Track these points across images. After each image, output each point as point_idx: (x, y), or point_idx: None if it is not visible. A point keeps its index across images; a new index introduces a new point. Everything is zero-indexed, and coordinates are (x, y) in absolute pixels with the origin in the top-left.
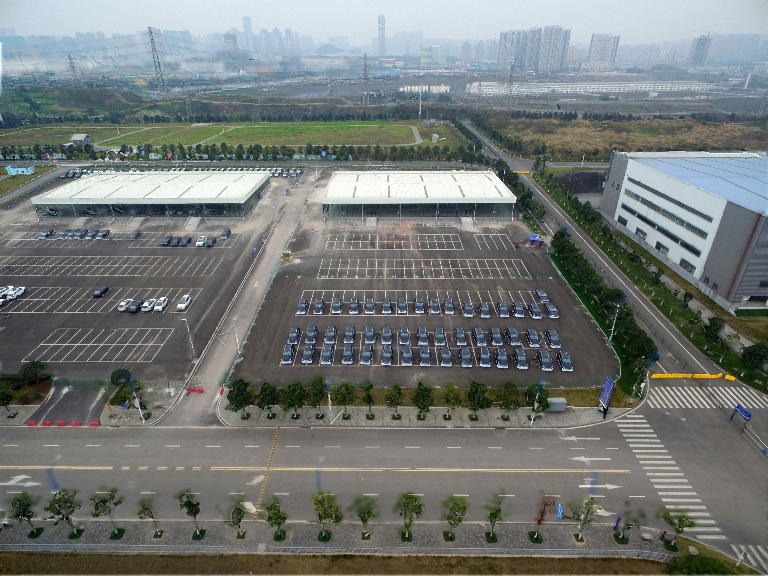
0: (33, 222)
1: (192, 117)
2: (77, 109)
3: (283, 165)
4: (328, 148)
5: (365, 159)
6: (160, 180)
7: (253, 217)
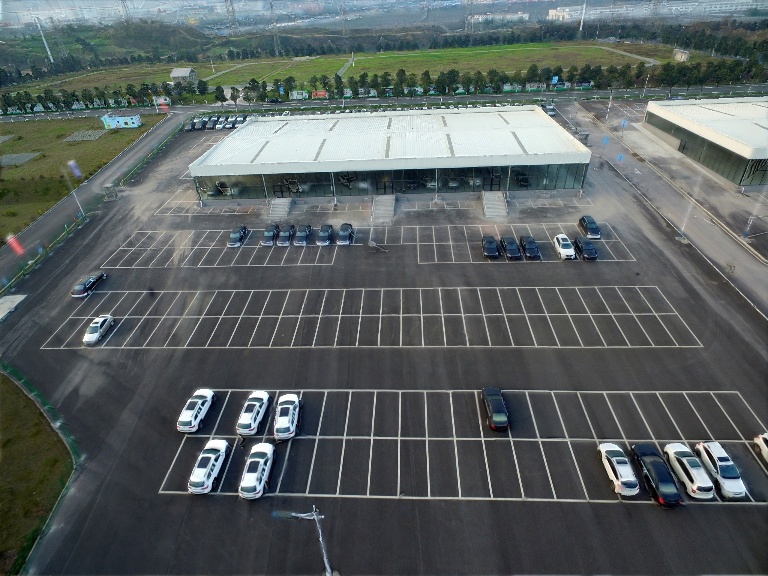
0: (192, 209)
1: (288, 50)
2: (137, 49)
3: (503, 99)
4: (562, 71)
5: (643, 84)
6: (374, 126)
7: (585, 188)
